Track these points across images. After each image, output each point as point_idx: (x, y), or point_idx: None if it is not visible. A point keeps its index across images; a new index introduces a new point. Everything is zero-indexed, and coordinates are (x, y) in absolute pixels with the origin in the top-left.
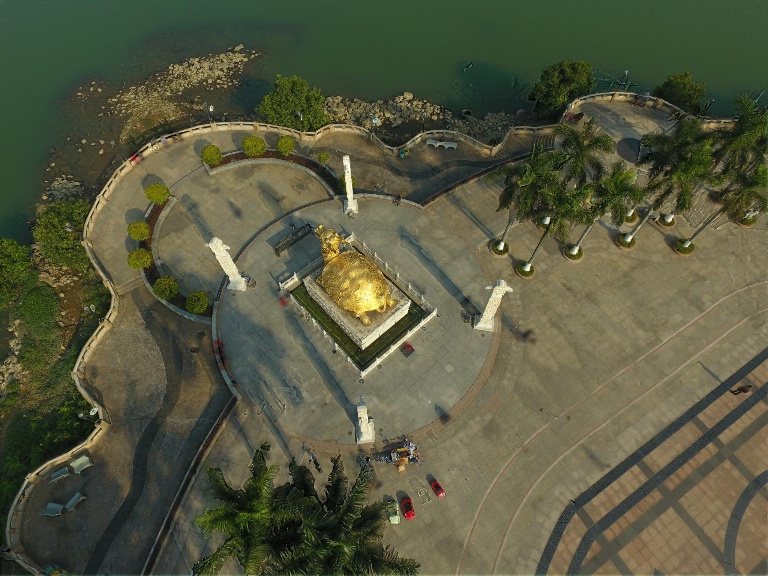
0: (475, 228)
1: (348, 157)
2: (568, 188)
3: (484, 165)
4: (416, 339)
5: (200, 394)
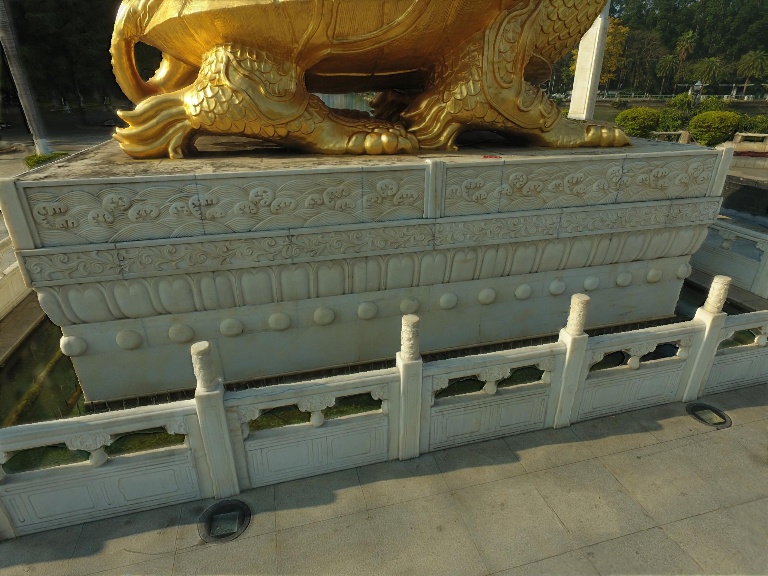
0: None
1: None
2: None
3: None
4: None
5: None
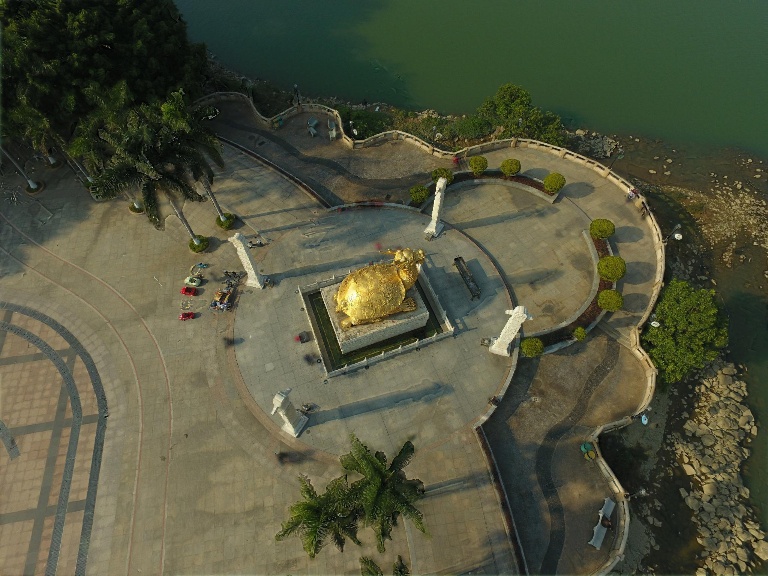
0: None
1: (522, 311)
2: None
3: (546, 575)
4: (312, 349)
5: (350, 195)
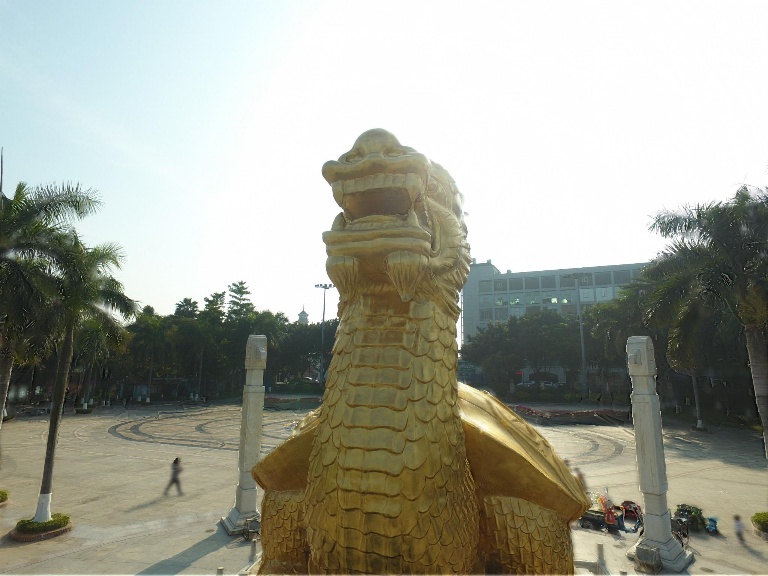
0: None
1: None
2: None
3: None
4: None
5: None
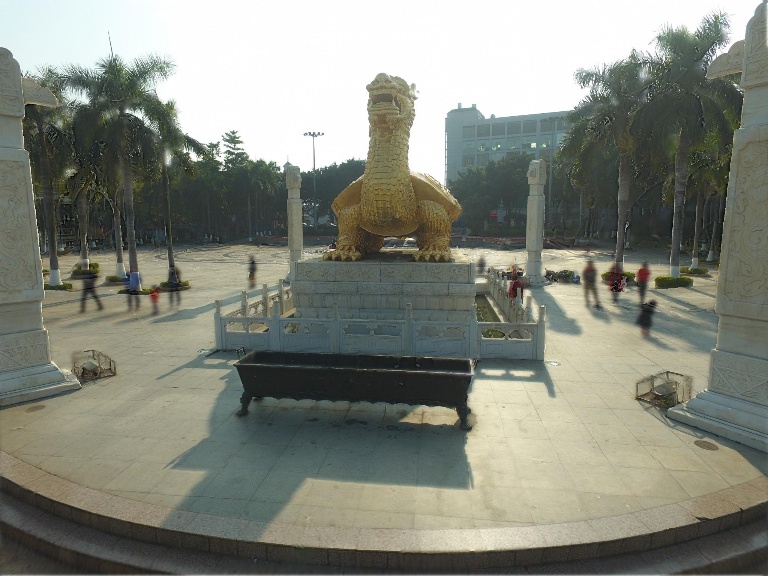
0: (91, 300)
1: None
2: (56, 191)
3: None
4: None
5: None
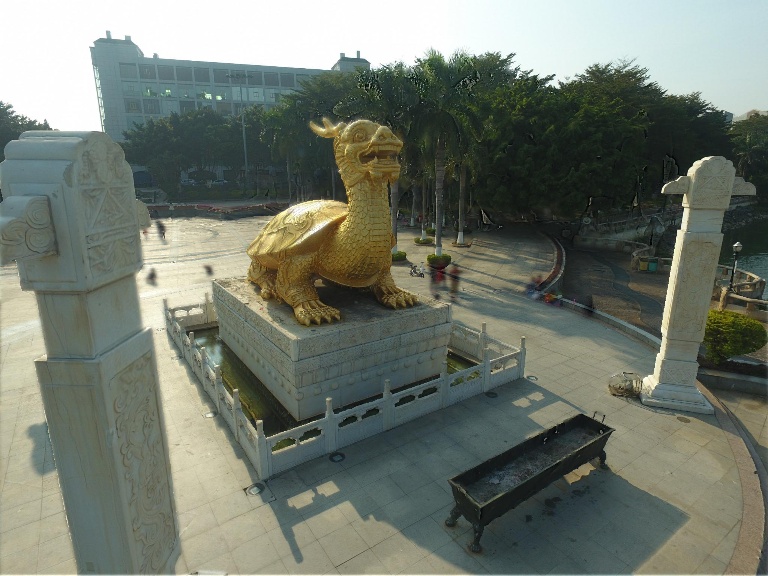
0: None
1: None
2: None
3: None
4: None
5: None
